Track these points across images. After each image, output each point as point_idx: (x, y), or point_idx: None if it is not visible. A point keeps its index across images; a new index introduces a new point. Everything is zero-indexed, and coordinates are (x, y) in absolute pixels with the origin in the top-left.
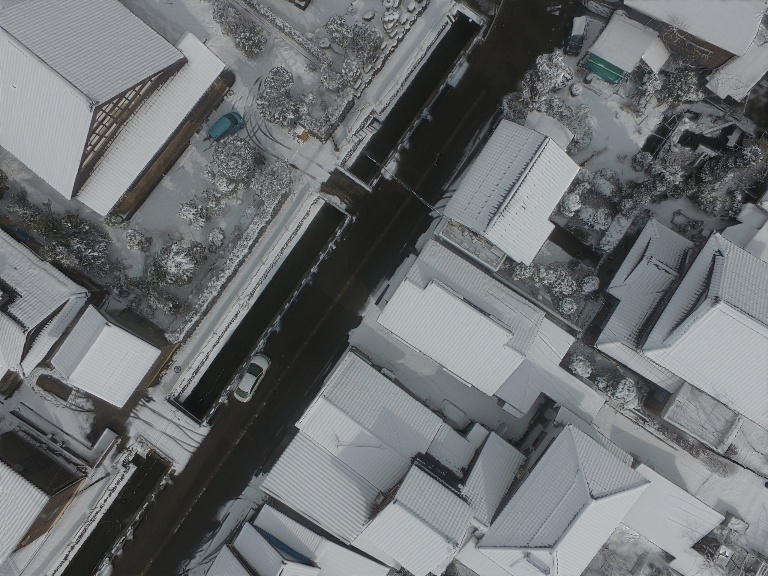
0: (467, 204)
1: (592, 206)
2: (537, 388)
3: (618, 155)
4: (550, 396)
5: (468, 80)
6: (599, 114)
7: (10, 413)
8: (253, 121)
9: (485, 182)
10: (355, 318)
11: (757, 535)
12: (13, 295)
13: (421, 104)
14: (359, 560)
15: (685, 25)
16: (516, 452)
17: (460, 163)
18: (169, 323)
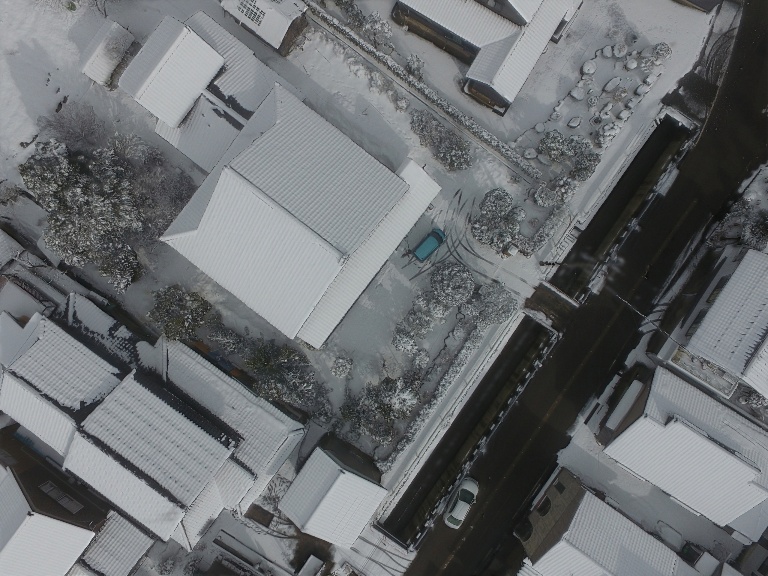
0: (717, 341)
1: None
2: None
3: None
4: None
5: (679, 188)
6: None
7: (214, 543)
8: (454, 236)
9: (737, 318)
10: (564, 438)
11: None
12: (236, 439)
13: (621, 209)
14: None
15: None
16: None
17: (671, 275)
18: (373, 447)
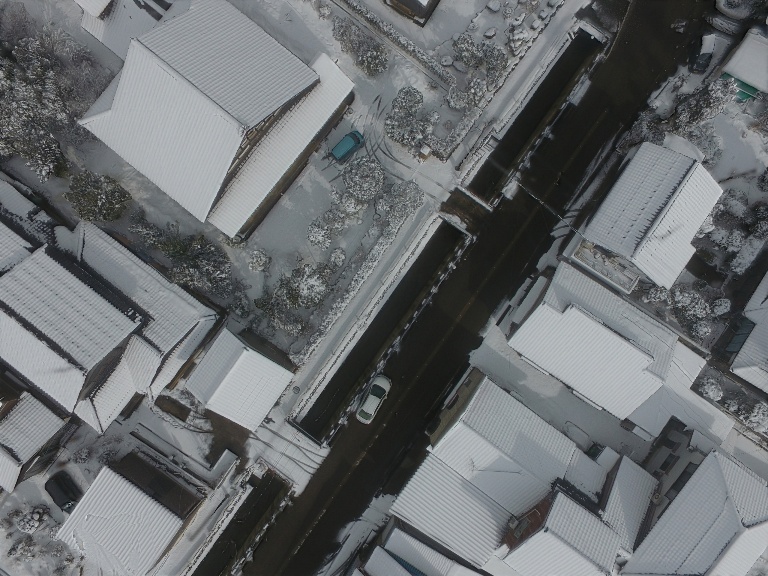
0: (610, 228)
1: (725, 228)
2: (668, 411)
3: (744, 175)
4: (681, 419)
5: (590, 98)
6: (725, 133)
7: (130, 434)
8: (372, 140)
9: (629, 206)
10: (476, 339)
11: None
12: (146, 318)
13: (538, 122)
14: None
15: None
16: (649, 476)
17: (582, 182)
18: (289, 344)
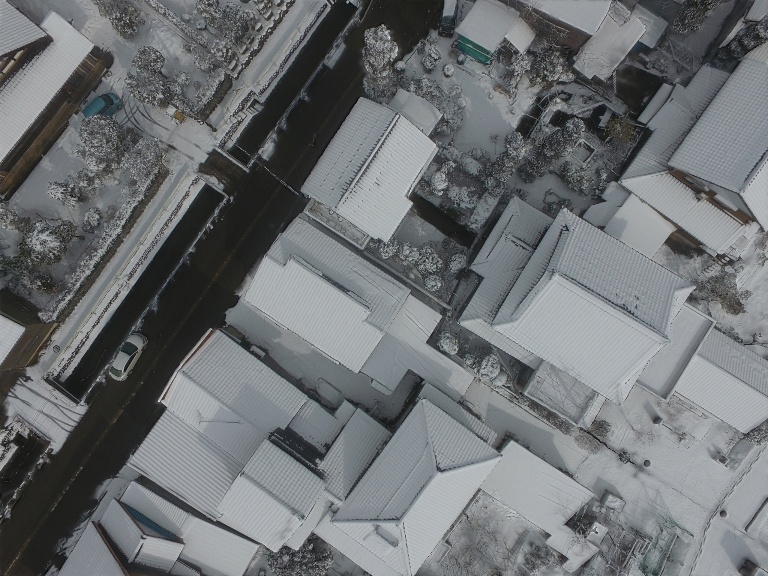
0: (323, 181)
1: (458, 184)
2: (404, 365)
3: (491, 135)
4: (417, 373)
5: (345, 61)
6: (473, 95)
7: None
8: (131, 102)
9: (340, 159)
10: (232, 297)
11: (636, 513)
12: None
13: None
14: (227, 536)
15: (539, 4)
16: (381, 428)
17: None
18: (46, 303)
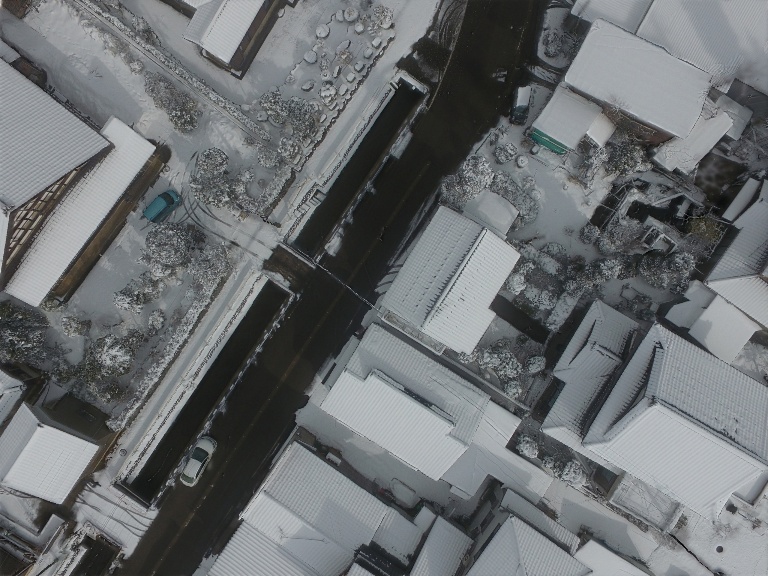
0: (405, 295)
1: (537, 286)
2: (484, 470)
3: (566, 228)
4: (497, 478)
5: (412, 151)
6: (547, 185)
7: None
8: (191, 198)
9: (423, 273)
10: (302, 398)
11: None
12: None
13: (366, 173)
14: None
15: (627, 105)
16: (463, 536)
17: (406, 237)
18: (112, 407)
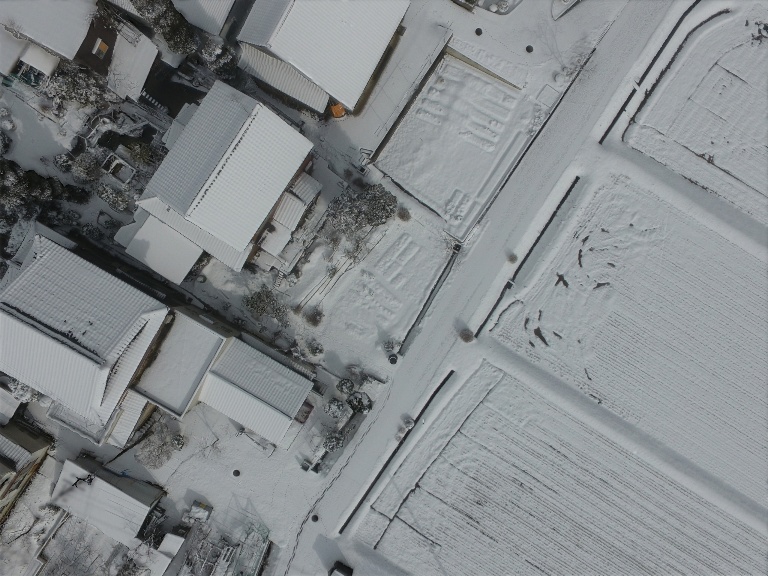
0: None
1: None
2: None
3: (43, 157)
4: None
5: None
6: (24, 117)
7: None
8: None
9: None
10: None
11: (225, 521)
12: None
13: None
14: None
15: (22, 28)
16: None
17: None
18: None
